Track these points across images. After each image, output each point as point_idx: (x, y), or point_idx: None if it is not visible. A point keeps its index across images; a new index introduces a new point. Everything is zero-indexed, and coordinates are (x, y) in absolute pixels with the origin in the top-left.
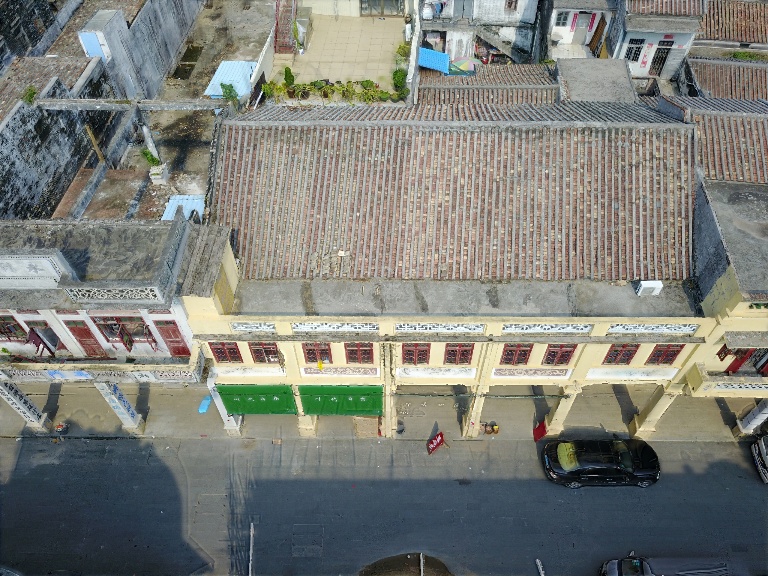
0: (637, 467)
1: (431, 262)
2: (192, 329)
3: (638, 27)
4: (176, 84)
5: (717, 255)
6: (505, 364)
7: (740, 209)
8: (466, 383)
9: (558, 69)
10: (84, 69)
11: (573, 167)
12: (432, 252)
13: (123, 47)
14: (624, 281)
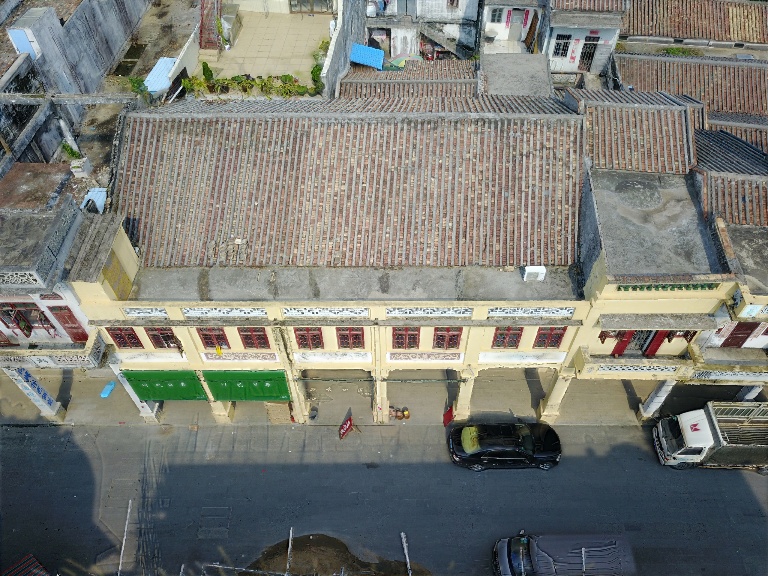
0: (538, 450)
1: (325, 249)
2: (86, 315)
3: (561, 23)
4: (116, 81)
5: (594, 240)
6: (398, 348)
7: (625, 197)
8: (363, 367)
9: (480, 64)
10: (11, 65)
11: (466, 157)
12: (326, 240)
13: (55, 44)
14: (512, 267)
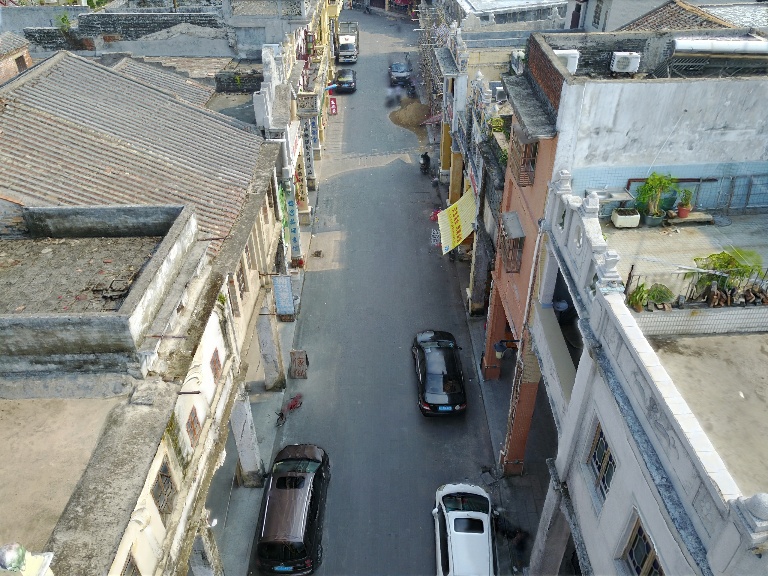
0: None
1: None
2: None
3: None
4: None
5: None
6: None
7: None
8: None
9: None
10: None
11: None
12: None
13: None
14: None
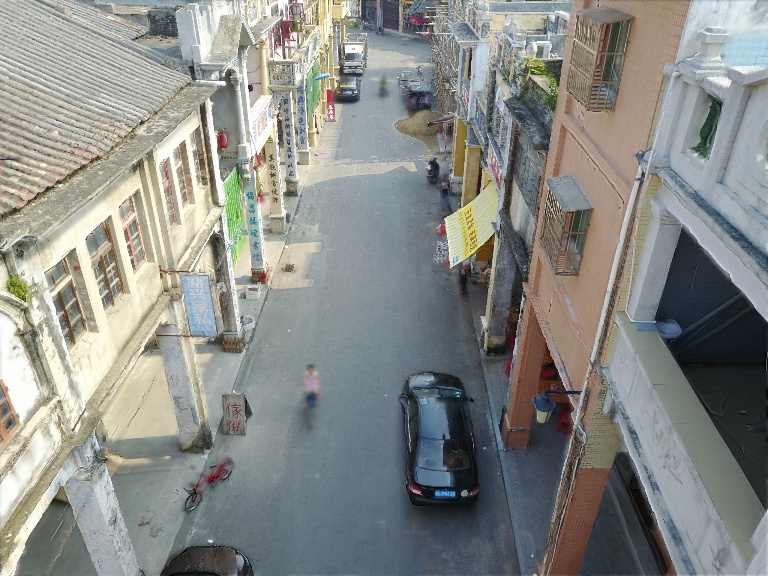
0: None
1: None
2: None
3: None
4: None
5: None
6: None
7: None
8: None
9: None
10: None
11: None
12: None
13: None
14: None
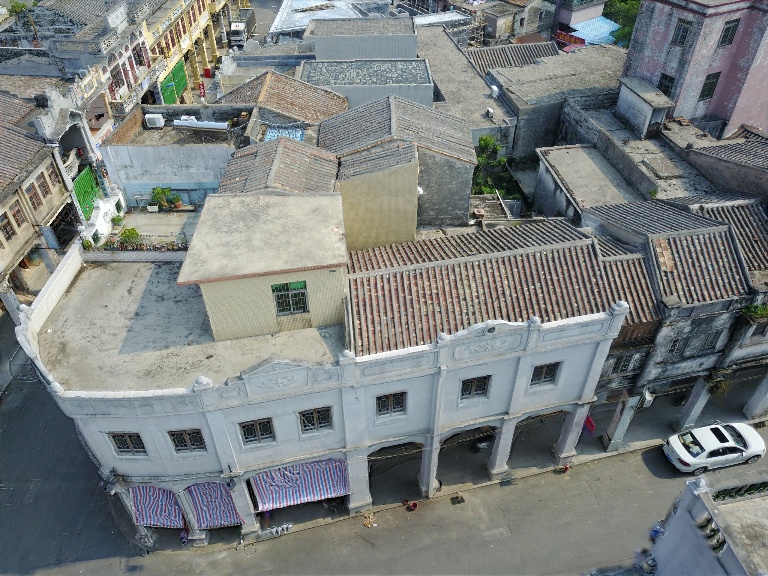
0: None
1: None
2: (148, 43)
3: None
4: None
5: None
6: None
7: None
8: None
9: None
10: None
11: None
12: None
13: None
14: None
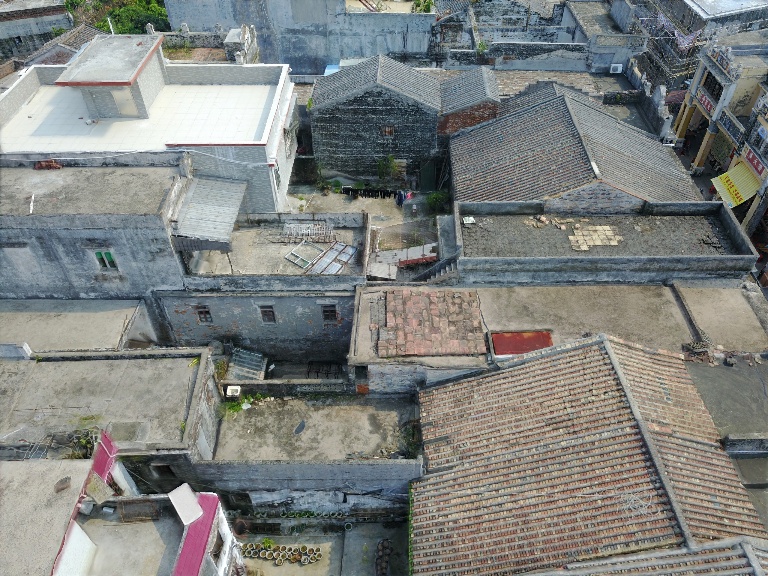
0: None
1: None
2: None
3: None
4: None
5: None
6: None
7: None
8: None
9: None
10: None
11: None
12: None
13: None
14: None
